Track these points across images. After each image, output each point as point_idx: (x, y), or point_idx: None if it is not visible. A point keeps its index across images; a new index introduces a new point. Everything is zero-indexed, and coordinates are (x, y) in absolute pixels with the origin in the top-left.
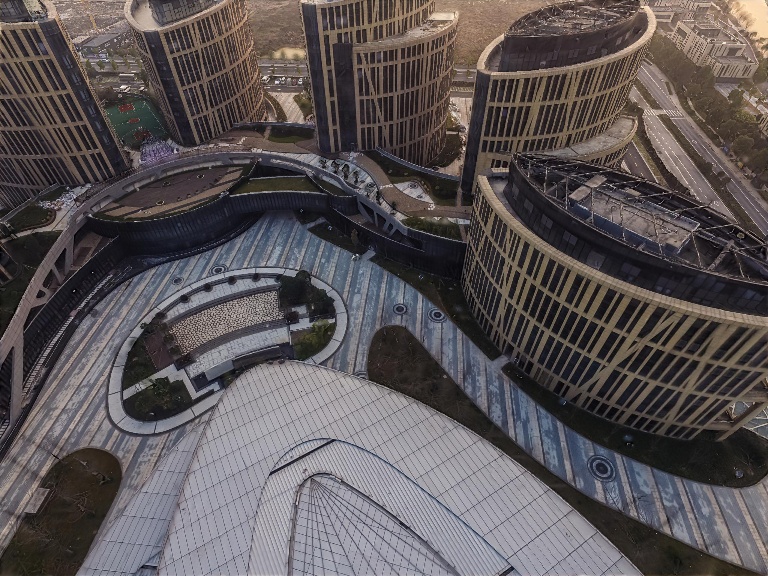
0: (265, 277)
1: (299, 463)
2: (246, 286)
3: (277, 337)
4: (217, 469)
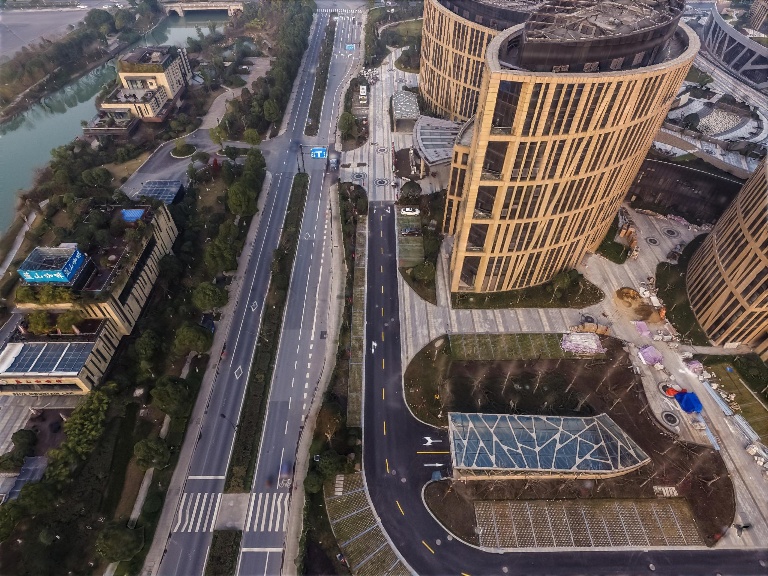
0: None
1: None
2: (728, 137)
3: (671, 114)
4: None
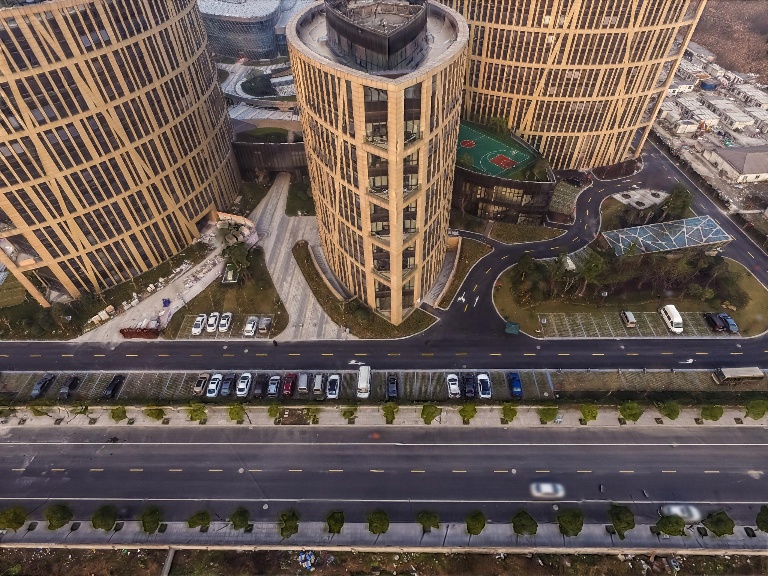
0: None
1: (245, 4)
2: None
3: None
4: None
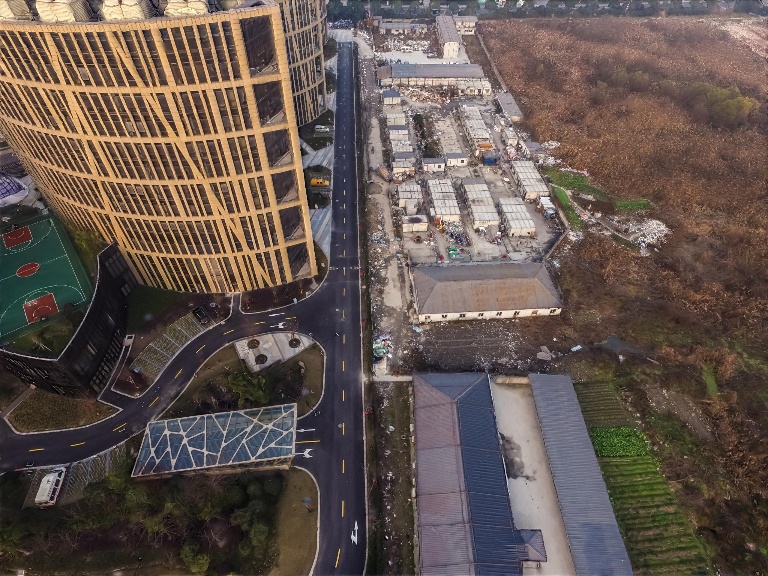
0: None
1: None
2: None
3: None
4: None
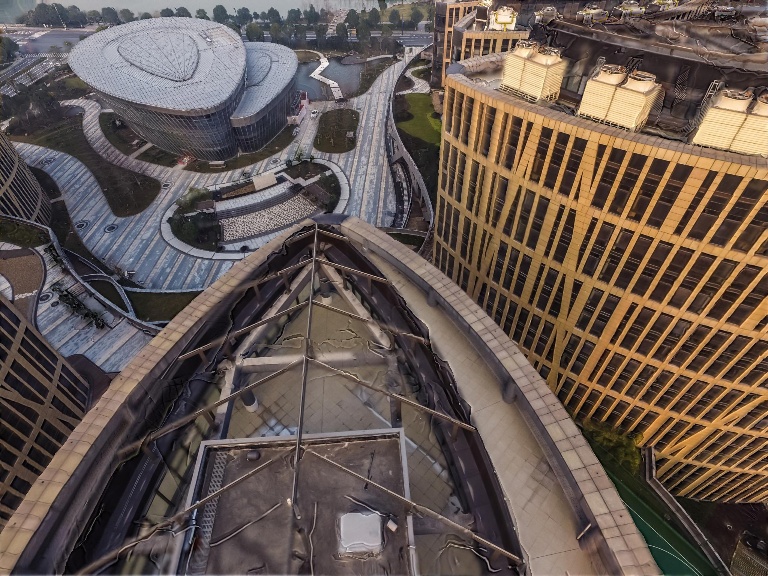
0: (235, 250)
1: (189, 83)
2: (254, 242)
3: (225, 204)
4: (226, 81)
